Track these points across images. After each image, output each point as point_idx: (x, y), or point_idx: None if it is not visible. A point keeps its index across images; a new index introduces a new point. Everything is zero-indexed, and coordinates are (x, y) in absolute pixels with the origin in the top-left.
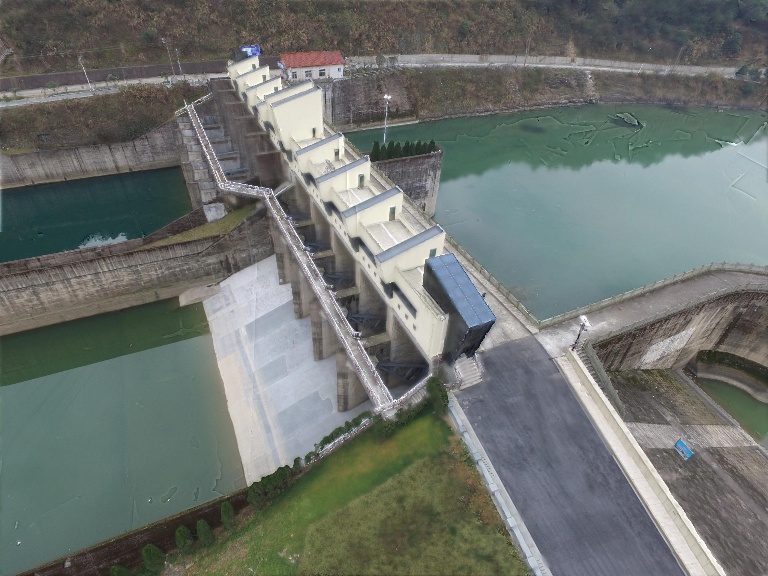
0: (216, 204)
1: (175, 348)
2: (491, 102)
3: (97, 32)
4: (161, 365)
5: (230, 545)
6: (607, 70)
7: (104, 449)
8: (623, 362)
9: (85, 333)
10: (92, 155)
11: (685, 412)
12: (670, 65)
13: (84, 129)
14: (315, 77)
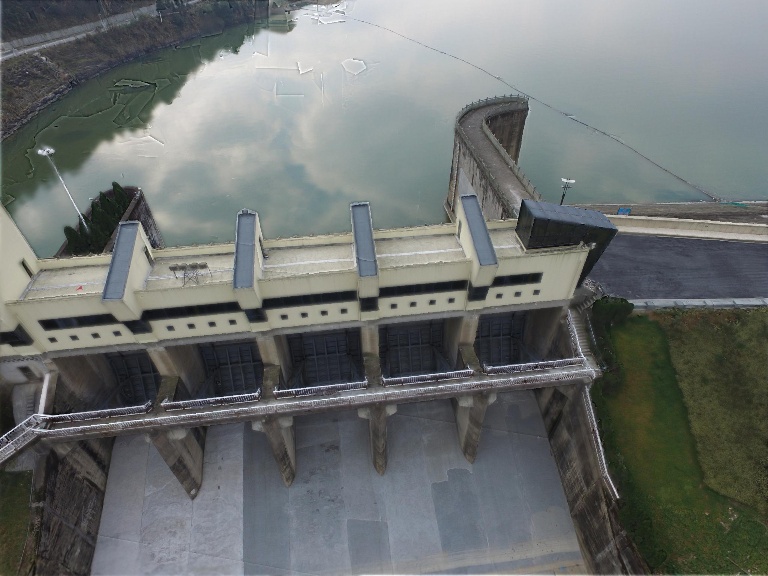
0: None
1: None
2: None
3: None
4: None
5: None
6: (51, 45)
7: None
8: None
9: None
10: None
11: None
12: (103, 20)
13: None
14: None
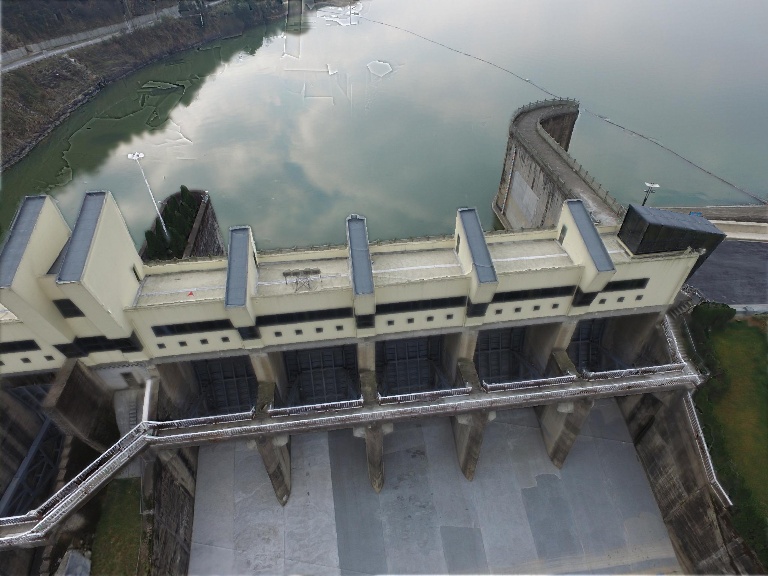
0: (62, 567)
1: None
2: (15, 136)
3: None
4: None
5: None
6: (79, 47)
7: None
8: None
9: None
10: None
11: None
12: (128, 21)
13: None
14: None
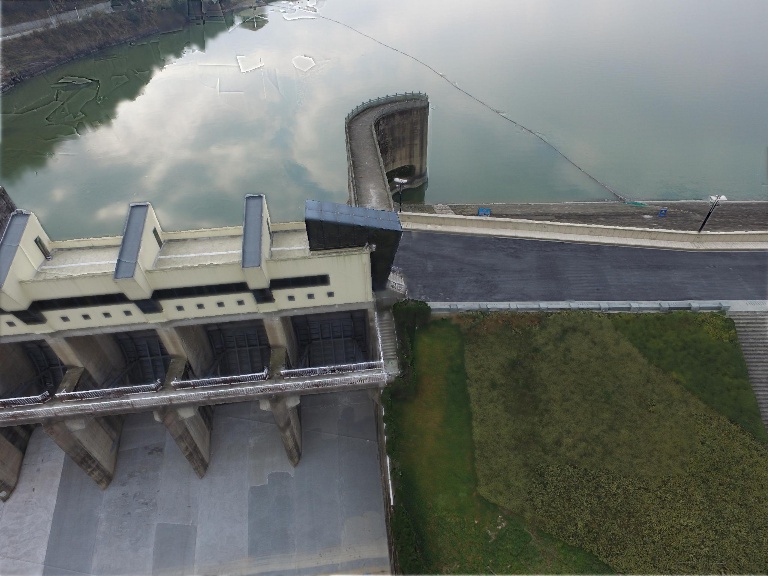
0: None
1: None
2: None
3: None
4: None
5: None
6: None
7: None
8: None
9: None
10: None
11: None
12: (52, 16)
13: None
14: None
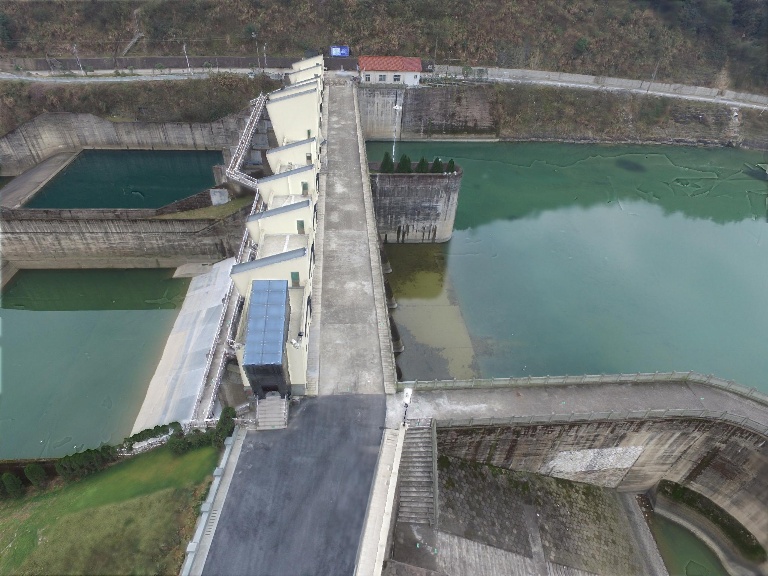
0: (221, 190)
1: (148, 314)
2: (592, 130)
3: (211, 24)
4: (125, 325)
5: (27, 506)
6: None
7: (46, 385)
8: (512, 460)
9: (97, 282)
10: (176, 131)
11: (578, 549)
12: None
13: (175, 107)
14: (389, 82)
